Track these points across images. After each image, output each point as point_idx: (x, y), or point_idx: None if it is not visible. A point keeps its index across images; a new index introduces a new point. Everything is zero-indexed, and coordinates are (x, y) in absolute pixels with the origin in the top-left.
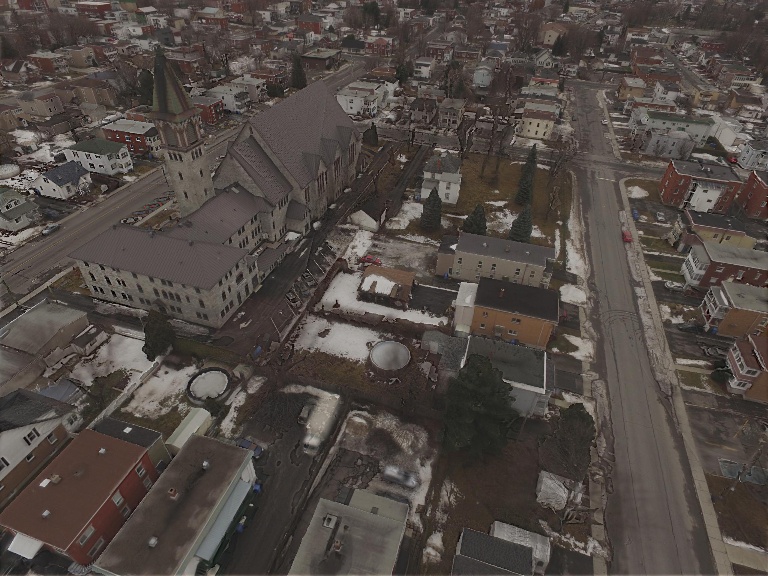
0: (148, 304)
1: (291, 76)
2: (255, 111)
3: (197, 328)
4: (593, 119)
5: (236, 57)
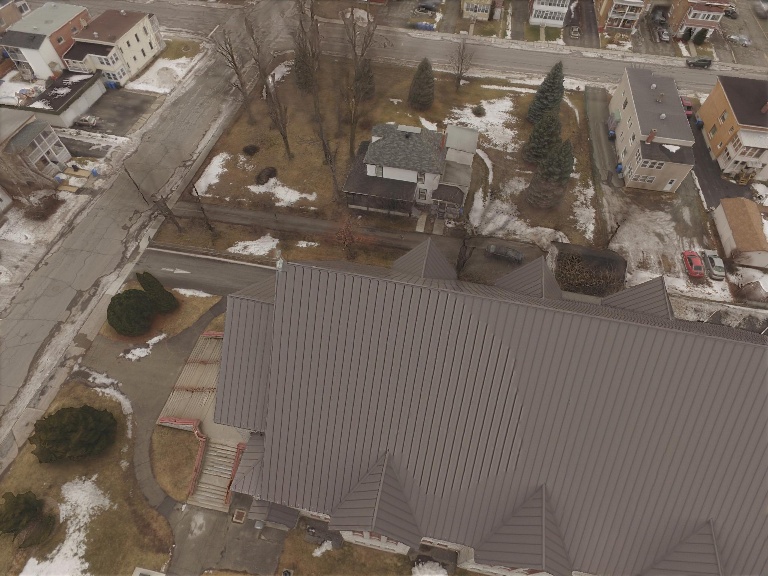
0: None
1: None
2: None
3: None
4: None
5: None
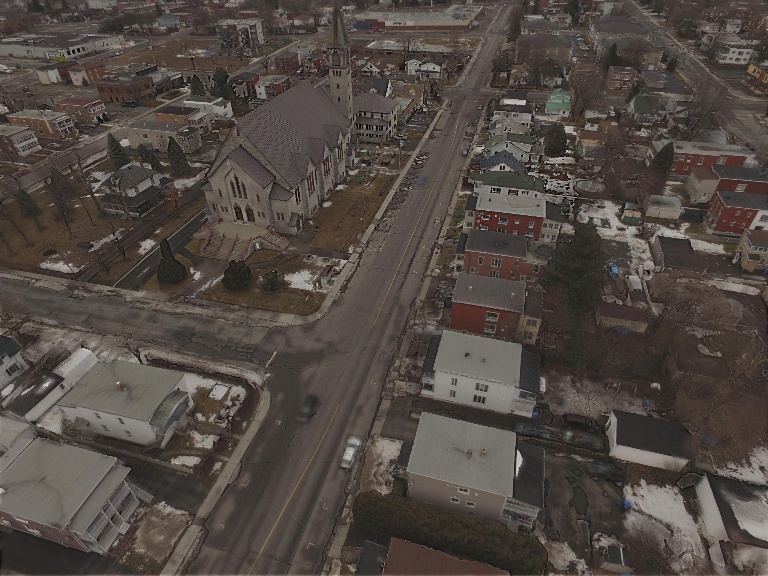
0: None
1: None
2: (406, 381)
3: None
4: None
5: None
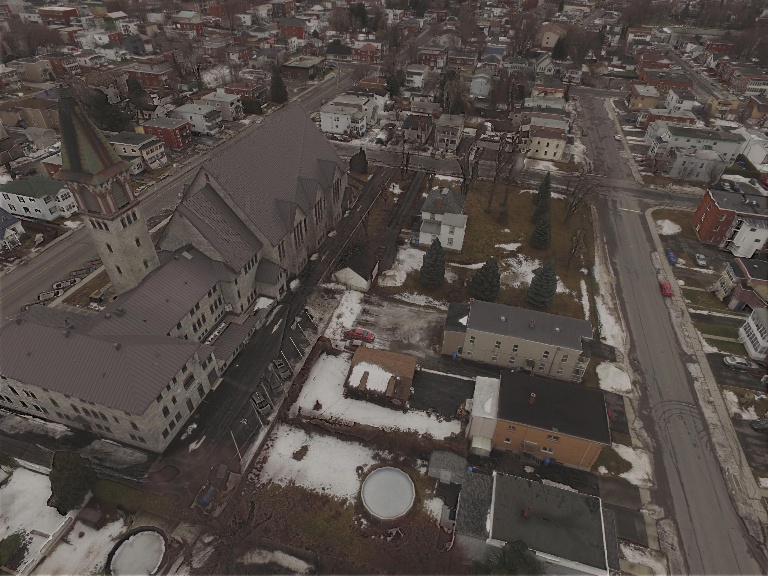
0: (68, 419)
1: (270, 89)
2: (228, 132)
3: (132, 453)
4: (605, 134)
5: (209, 69)
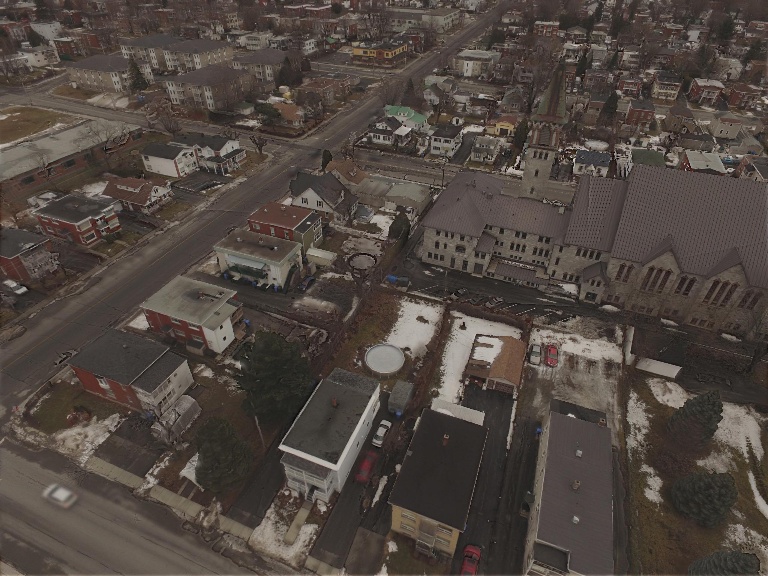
0: None
1: None
2: None
3: None
4: None
5: None
